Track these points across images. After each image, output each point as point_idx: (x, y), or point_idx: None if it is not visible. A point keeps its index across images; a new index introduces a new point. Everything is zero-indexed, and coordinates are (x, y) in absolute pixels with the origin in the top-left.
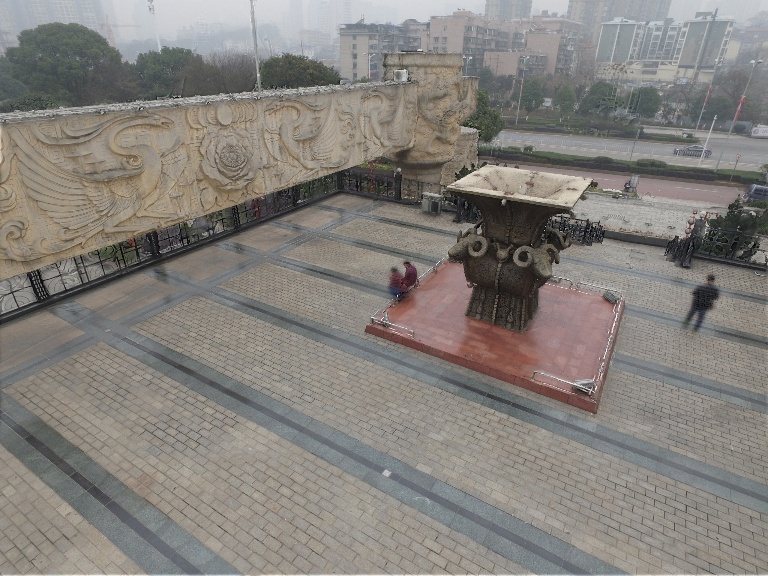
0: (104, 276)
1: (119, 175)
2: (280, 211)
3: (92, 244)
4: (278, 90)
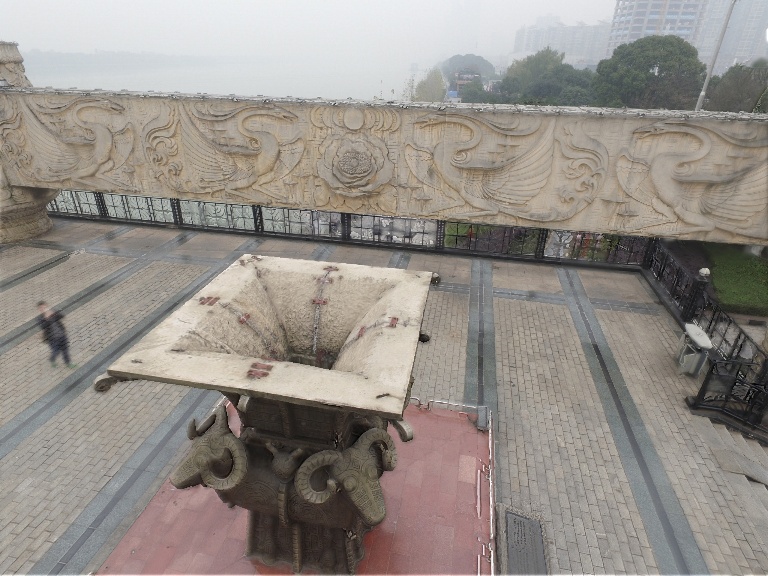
0: (301, 234)
1: (235, 151)
2: (509, 254)
3: (219, 197)
4: (495, 104)
